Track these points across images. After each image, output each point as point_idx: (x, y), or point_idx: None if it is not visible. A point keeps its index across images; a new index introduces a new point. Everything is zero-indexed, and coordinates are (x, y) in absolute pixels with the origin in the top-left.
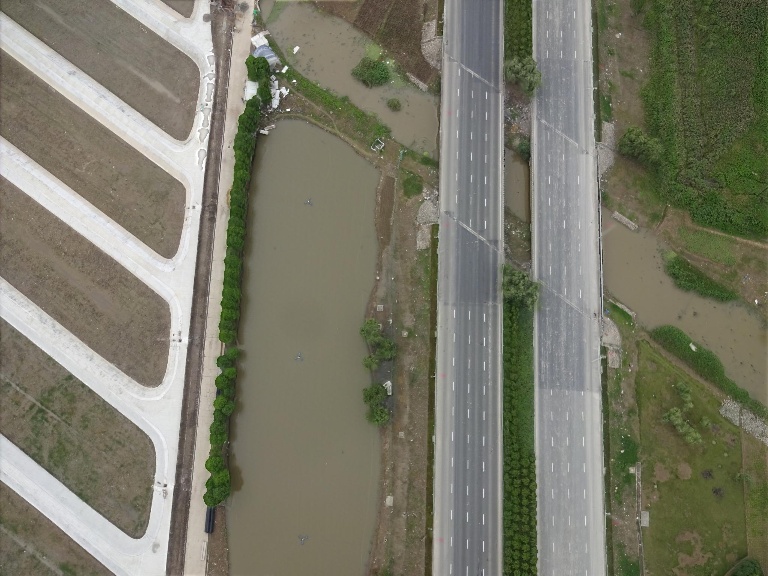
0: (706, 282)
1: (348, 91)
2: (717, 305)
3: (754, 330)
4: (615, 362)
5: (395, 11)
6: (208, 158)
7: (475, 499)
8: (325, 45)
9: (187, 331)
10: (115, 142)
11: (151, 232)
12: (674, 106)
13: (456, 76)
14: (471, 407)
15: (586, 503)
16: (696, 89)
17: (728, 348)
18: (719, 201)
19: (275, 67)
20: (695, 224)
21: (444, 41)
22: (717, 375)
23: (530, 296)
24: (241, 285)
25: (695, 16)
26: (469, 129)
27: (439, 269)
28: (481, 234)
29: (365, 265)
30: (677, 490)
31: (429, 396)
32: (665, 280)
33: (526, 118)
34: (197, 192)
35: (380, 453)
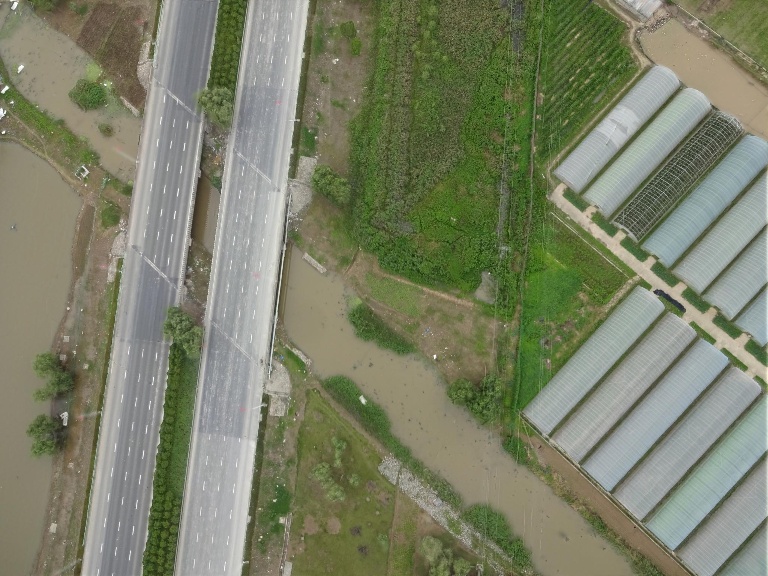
0: (384, 333)
1: (65, 114)
2: (395, 358)
3: (428, 387)
4: (280, 410)
5: (117, 30)
6: None
7: (125, 535)
8: (48, 64)
9: None
10: None
11: None
12: (379, 142)
13: (161, 103)
14: (132, 445)
15: (228, 549)
16: (406, 123)
17: (399, 403)
18: (408, 248)
19: None
20: (383, 271)
21: (154, 65)
22: (381, 431)
23: (187, 341)
24: None
25: (418, 41)
26: (166, 160)
27: (119, 304)
28: (163, 271)
29: (57, 295)
30: (323, 544)
31: (95, 431)
32: (346, 328)
33: None
34: None
35: (50, 481)
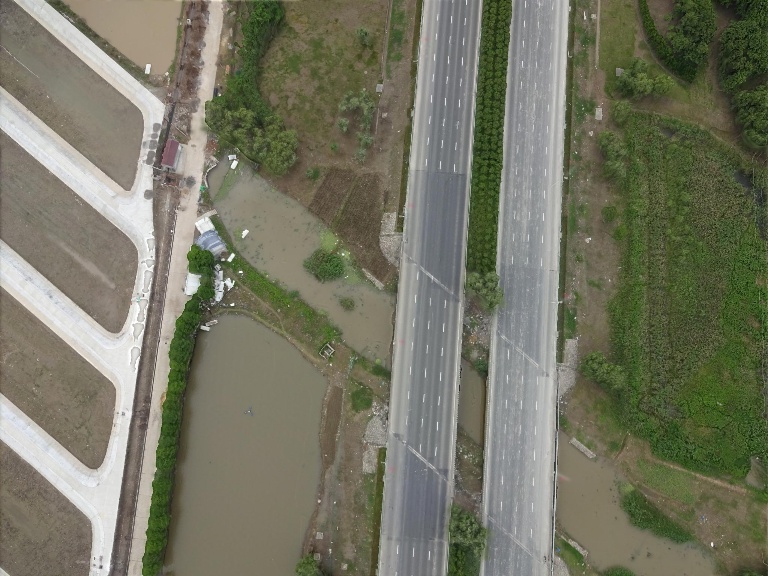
0: (662, 522)
1: (299, 284)
2: (672, 546)
3: (708, 575)
4: None
5: (354, 197)
6: (142, 356)
7: None
8: (277, 230)
9: (109, 556)
10: (41, 331)
11: (76, 437)
12: (641, 325)
13: (414, 280)
14: None
15: None
16: (665, 306)
17: None
18: (681, 434)
19: (220, 255)
20: (655, 457)
21: (404, 239)
22: None
23: (477, 544)
24: (171, 504)
25: (669, 224)
26: (425, 341)
27: (384, 499)
28: (431, 462)
29: (306, 486)
30: None
31: None
32: (620, 516)
33: (486, 329)
34: (128, 396)
35: None
